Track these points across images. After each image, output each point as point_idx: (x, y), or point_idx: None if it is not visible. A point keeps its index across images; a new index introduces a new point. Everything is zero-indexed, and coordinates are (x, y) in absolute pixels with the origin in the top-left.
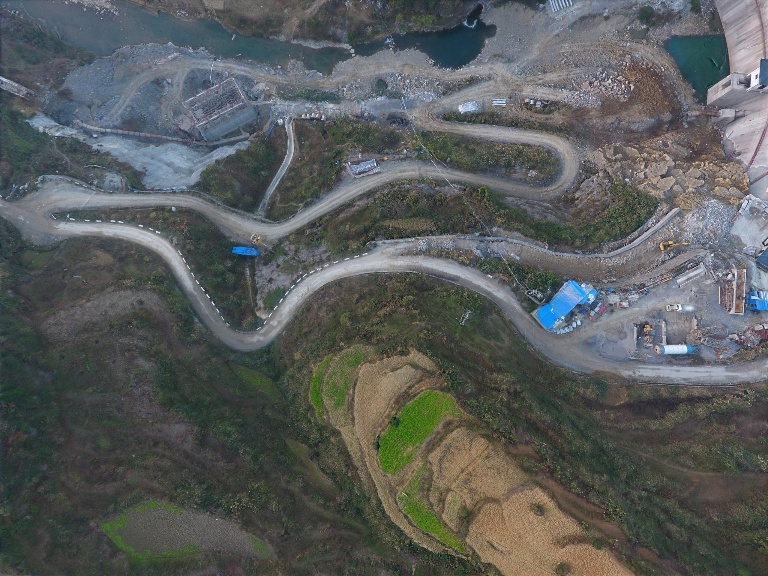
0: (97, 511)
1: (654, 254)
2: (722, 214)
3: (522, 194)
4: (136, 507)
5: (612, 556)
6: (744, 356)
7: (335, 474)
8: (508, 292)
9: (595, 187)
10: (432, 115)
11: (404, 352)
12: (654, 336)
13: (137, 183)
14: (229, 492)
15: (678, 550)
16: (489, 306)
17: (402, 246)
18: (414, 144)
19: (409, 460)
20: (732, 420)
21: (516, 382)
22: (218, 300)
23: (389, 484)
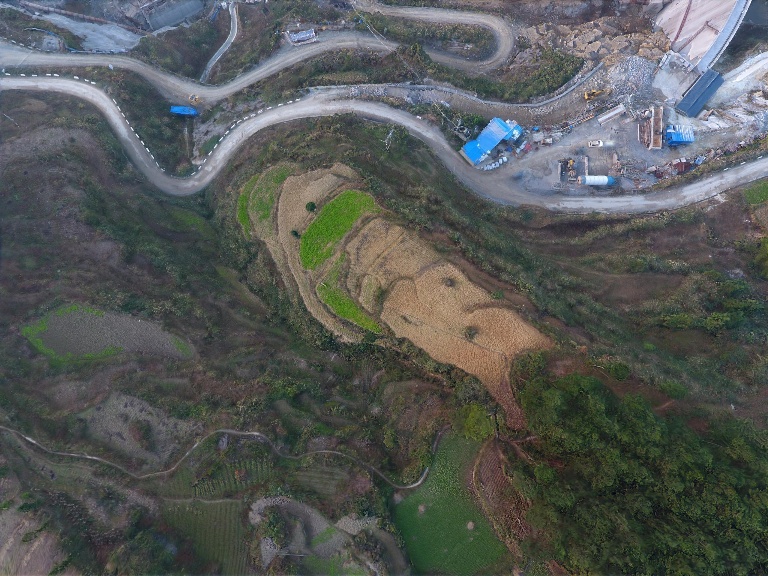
0: (18, 317)
1: (579, 104)
2: (643, 67)
3: (459, 67)
4: (57, 310)
5: (518, 317)
6: (661, 184)
7: (262, 290)
8: (437, 132)
9: (527, 56)
10: (373, 0)
11: (328, 165)
12: (578, 172)
13: (75, 44)
14: (153, 300)
15: (586, 322)
16: (418, 143)
17: (334, 92)
18: (352, 15)
19: (329, 254)
20: (648, 235)
21: (438, 194)
22: (153, 147)
23: (310, 280)
